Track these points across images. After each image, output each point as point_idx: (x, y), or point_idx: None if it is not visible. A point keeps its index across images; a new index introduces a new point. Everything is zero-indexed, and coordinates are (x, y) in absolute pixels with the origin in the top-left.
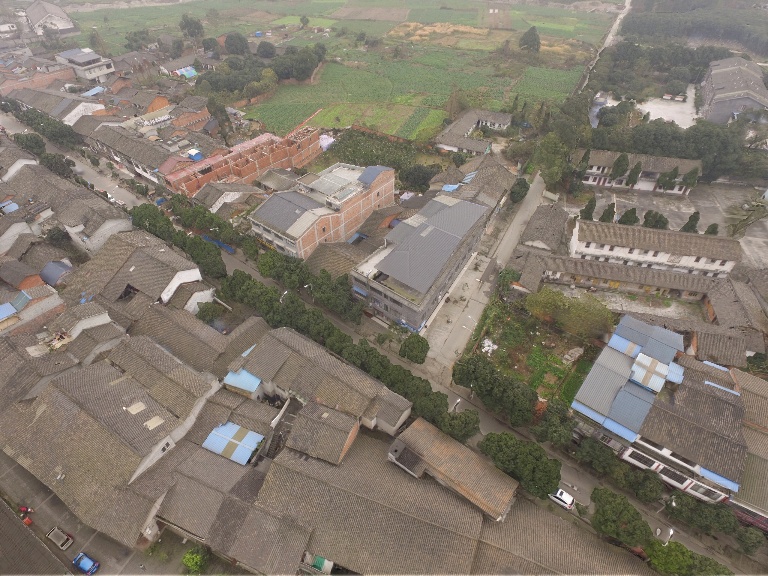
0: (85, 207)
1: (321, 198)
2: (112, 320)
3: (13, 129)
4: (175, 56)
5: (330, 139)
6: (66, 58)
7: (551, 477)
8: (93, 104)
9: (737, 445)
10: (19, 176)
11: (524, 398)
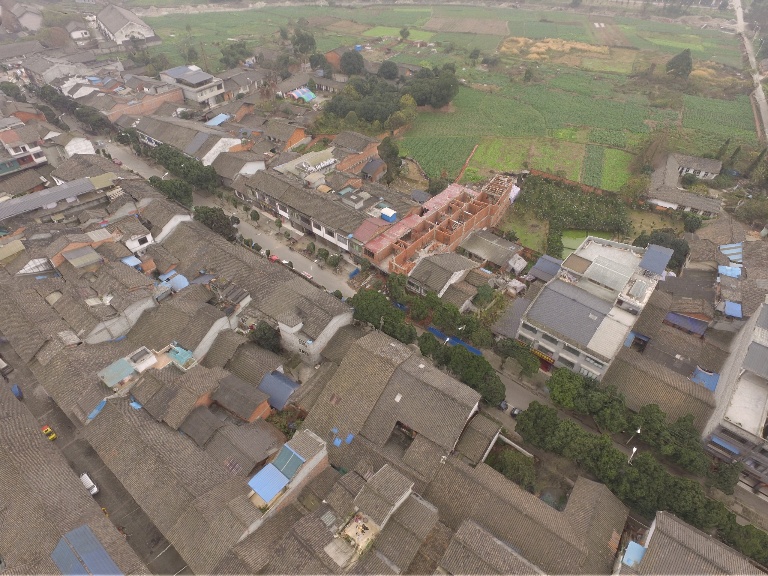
0: (295, 294)
1: (597, 290)
2: (411, 490)
3: (131, 164)
4: (286, 75)
5: (515, 188)
6: (174, 77)
7: None
8: (231, 139)
9: None
10: (177, 237)
11: None
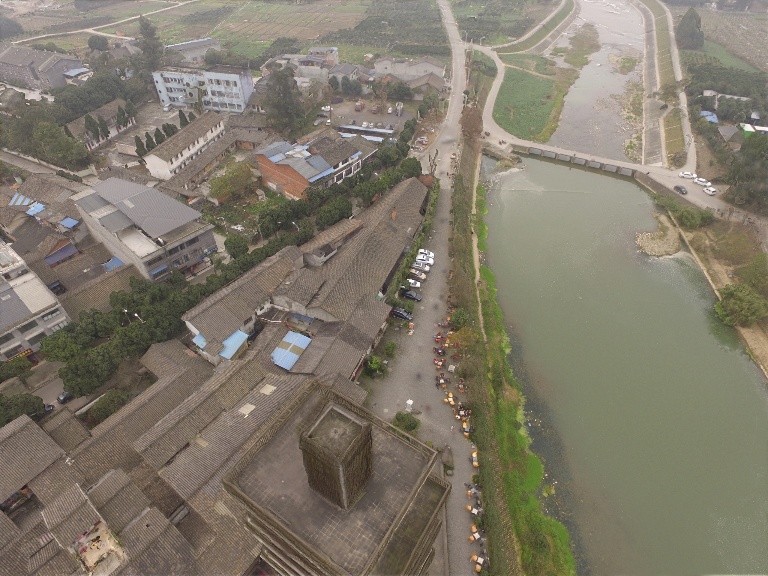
0: None
1: None
2: None
3: None
4: None
5: None
6: None
7: (346, 201)
8: None
9: (344, 142)
10: None
11: (299, 199)
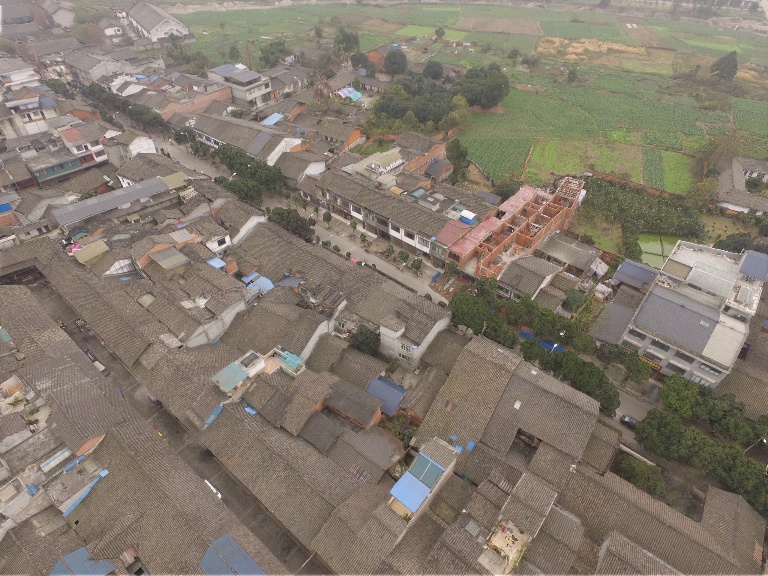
0: (392, 298)
1: (699, 296)
2: None
3: (189, 163)
4: (331, 74)
5: (582, 191)
6: (223, 76)
7: None
8: (292, 139)
9: None
10: (255, 238)
11: None
